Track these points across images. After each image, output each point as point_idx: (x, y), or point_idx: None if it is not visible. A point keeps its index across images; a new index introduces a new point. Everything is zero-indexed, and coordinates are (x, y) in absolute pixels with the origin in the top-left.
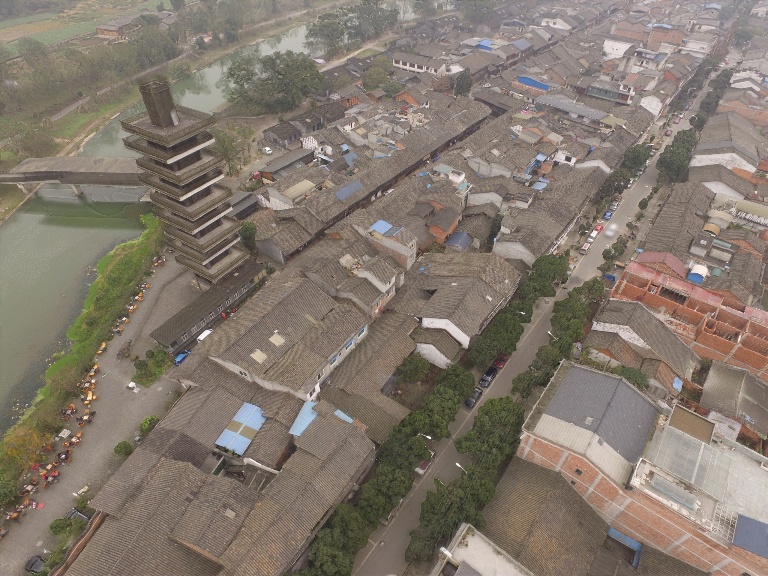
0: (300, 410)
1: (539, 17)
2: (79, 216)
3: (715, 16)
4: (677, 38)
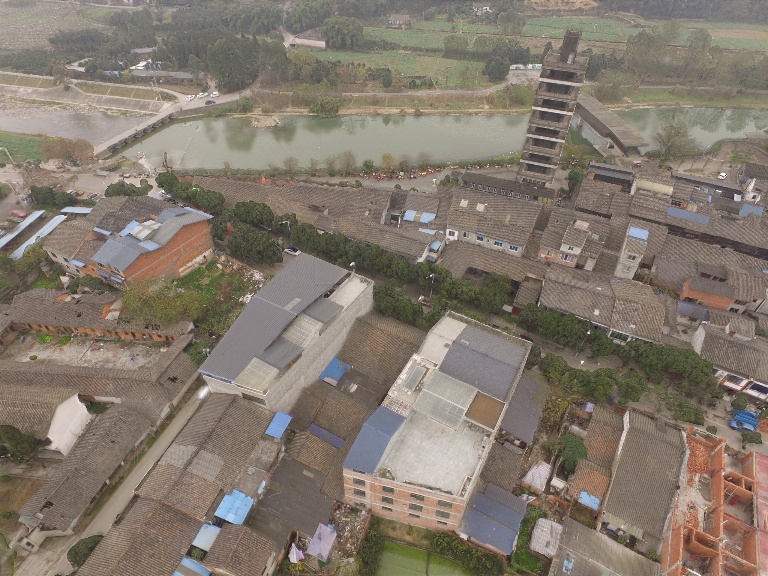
0: None
1: None
2: None
3: None
4: None
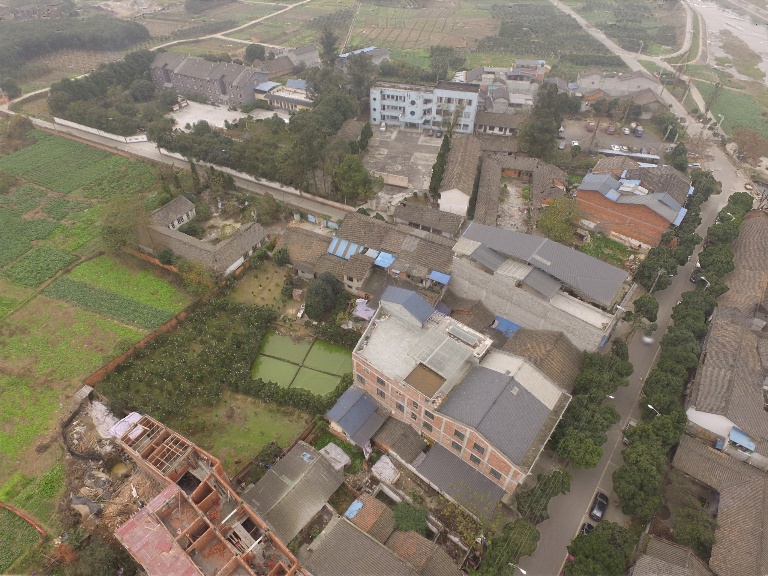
0: None
1: None
2: None
3: None
4: None
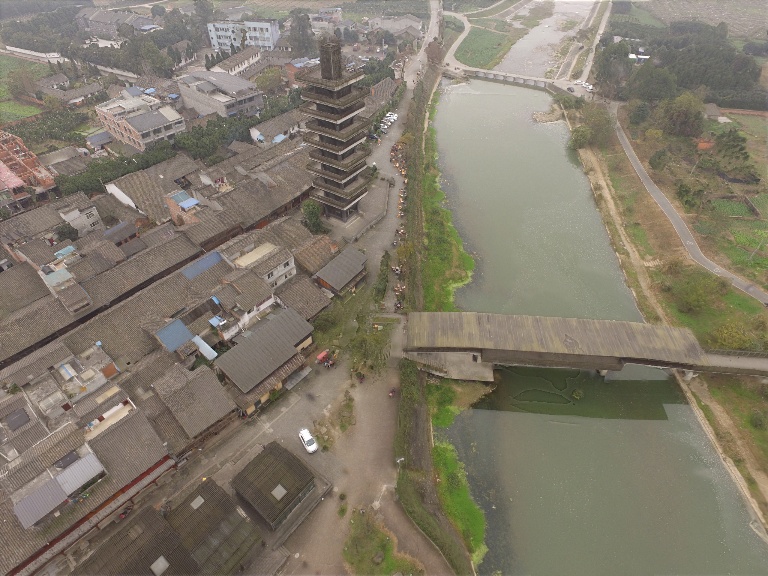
0: None
1: None
2: None
3: None
4: None
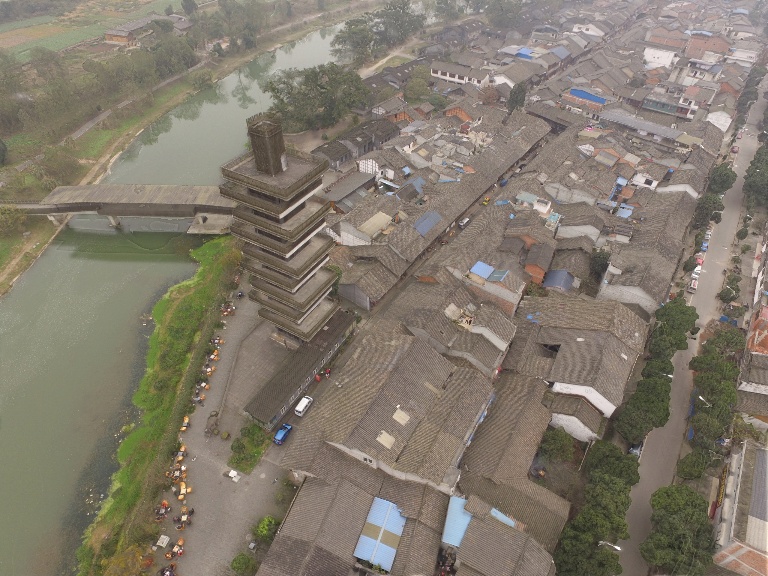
0: (447, 509)
1: (568, 22)
2: (121, 252)
3: (749, 22)
4: (718, 46)
